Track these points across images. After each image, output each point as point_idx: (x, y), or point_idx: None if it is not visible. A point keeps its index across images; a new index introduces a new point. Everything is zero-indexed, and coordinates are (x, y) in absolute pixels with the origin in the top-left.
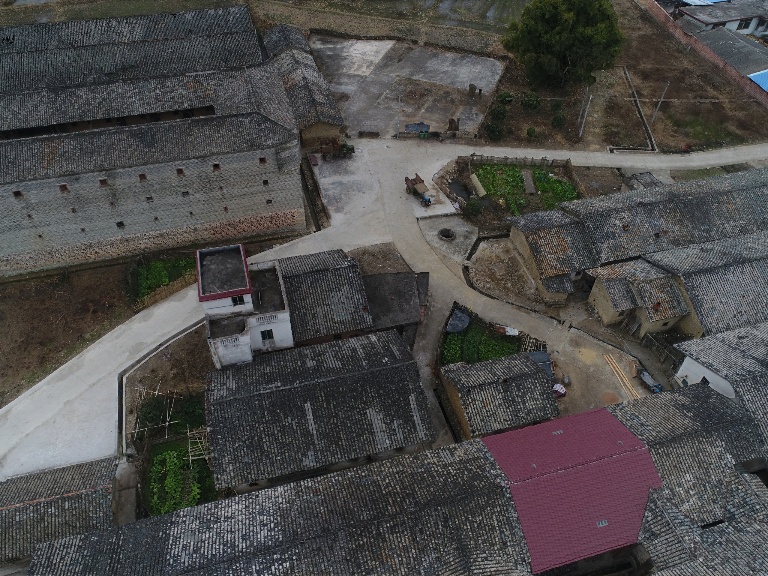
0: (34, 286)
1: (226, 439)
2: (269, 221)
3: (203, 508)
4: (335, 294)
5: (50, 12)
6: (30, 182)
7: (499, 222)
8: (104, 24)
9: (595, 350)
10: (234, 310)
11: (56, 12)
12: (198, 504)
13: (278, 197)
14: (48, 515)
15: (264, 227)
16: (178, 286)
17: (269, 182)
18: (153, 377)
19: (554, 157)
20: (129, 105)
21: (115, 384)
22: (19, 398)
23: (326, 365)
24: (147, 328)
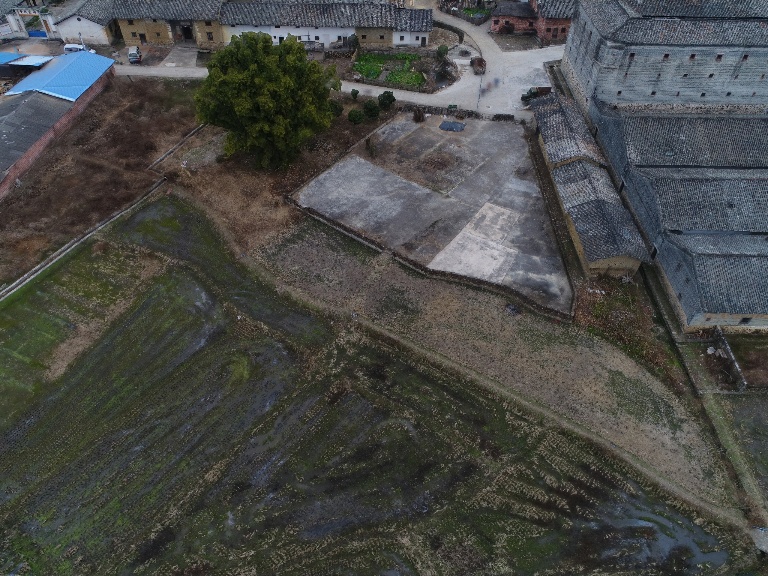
0: None
1: None
2: None
3: None
4: None
5: None
6: None
7: (428, 49)
8: None
9: (416, 8)
10: None
11: None
12: None
13: None
14: None
15: None
16: None
17: None
18: None
19: (347, 86)
20: None
21: None
22: None
23: None
24: None
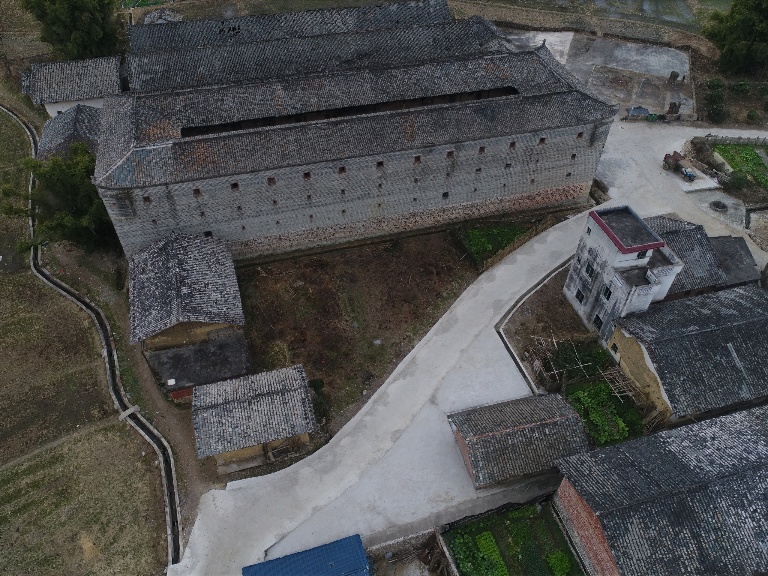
0: (370, 251)
1: (672, 374)
2: (561, 193)
3: (679, 431)
4: (690, 253)
5: (231, 6)
6: (394, 153)
7: (765, 195)
8: (318, 15)
9: None
10: (633, 264)
11: (237, 6)
12: (629, 435)
13: (577, 170)
14: (534, 439)
15: (554, 199)
16: (508, 251)
17: (576, 156)
18: (524, 329)
19: None
20: (440, 85)
21: (496, 335)
22: (417, 347)
23: (723, 312)
24: (497, 287)
